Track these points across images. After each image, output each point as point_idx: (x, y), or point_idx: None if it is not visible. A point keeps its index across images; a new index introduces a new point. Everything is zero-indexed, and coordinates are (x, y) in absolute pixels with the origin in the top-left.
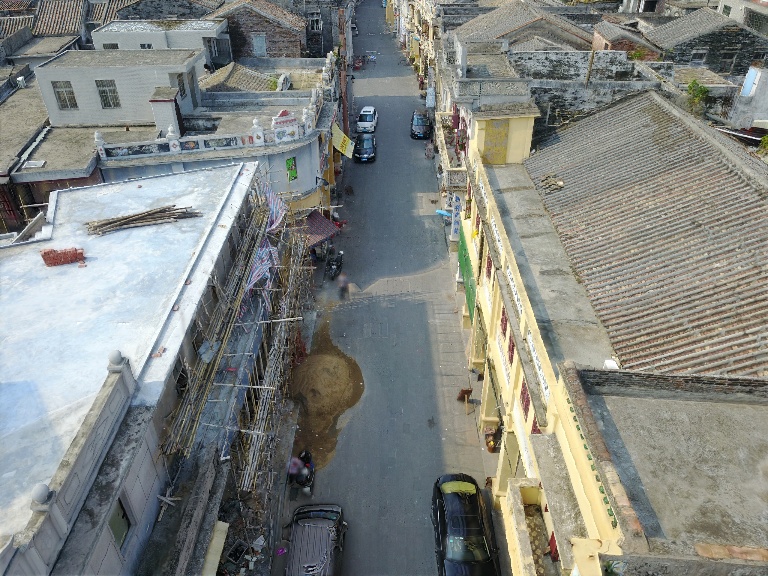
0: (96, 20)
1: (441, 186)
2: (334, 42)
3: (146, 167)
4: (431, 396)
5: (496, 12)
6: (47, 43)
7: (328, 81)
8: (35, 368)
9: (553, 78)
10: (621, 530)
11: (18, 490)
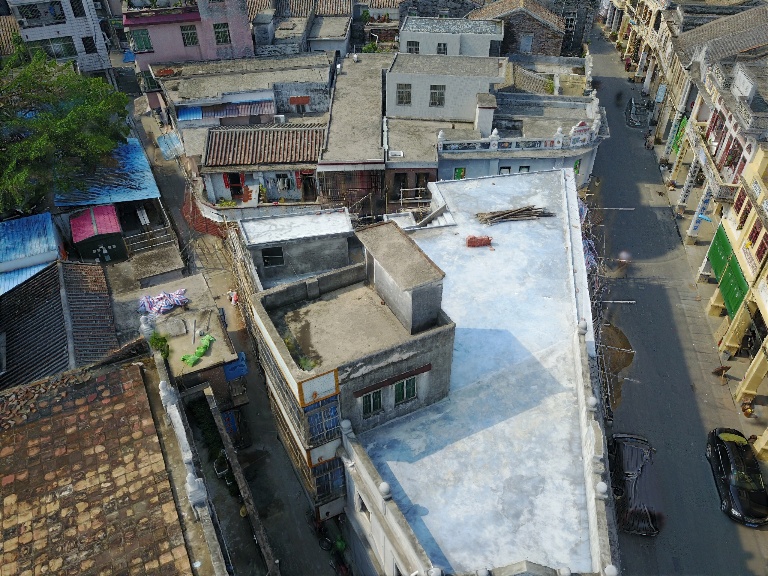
0: (362, 1)
1: (668, 180)
2: (584, 39)
3: (471, 160)
4: (690, 367)
5: (740, 16)
6: (330, 24)
7: None
8: (507, 322)
9: None
10: None
11: (545, 397)
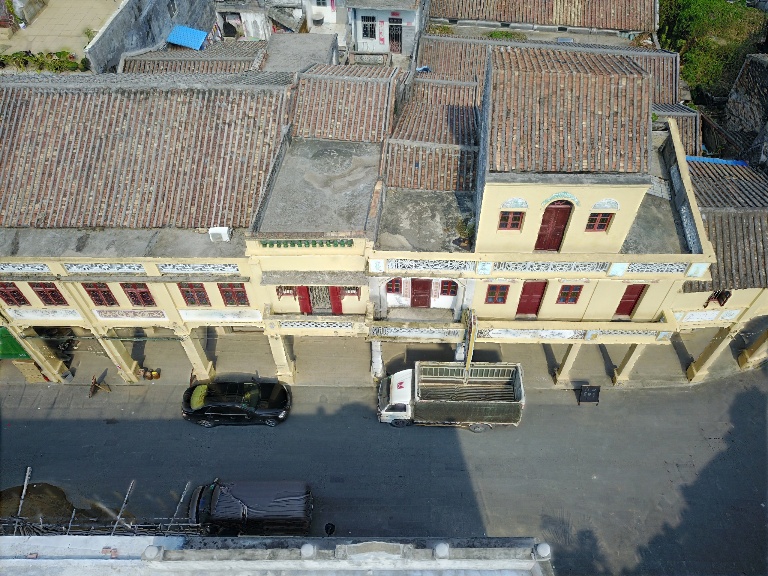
0: None
1: None
2: None
3: None
4: (77, 419)
5: None
6: None
7: None
8: None
9: None
10: (363, 238)
11: None
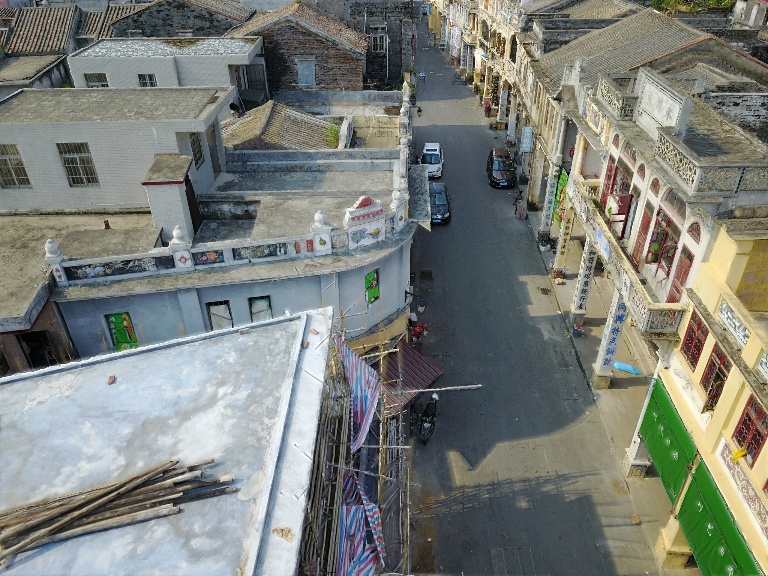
0: (89, 34)
1: (553, 268)
2: (403, 67)
3: (134, 297)
4: None
5: (617, 26)
6: (22, 65)
7: (407, 128)
8: None
9: (767, 134)
10: None
11: None
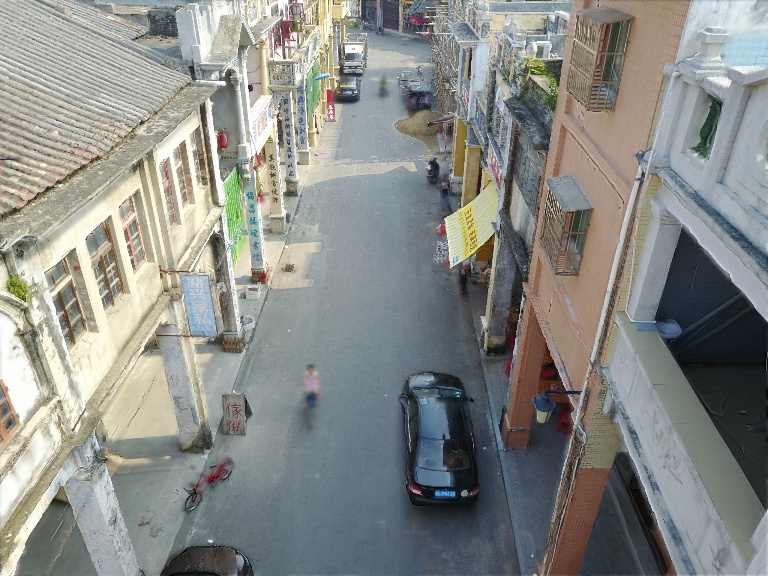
0: None
1: None
2: None
3: None
4: (351, 122)
5: None
6: None
7: None
8: None
9: None
10: None
11: None
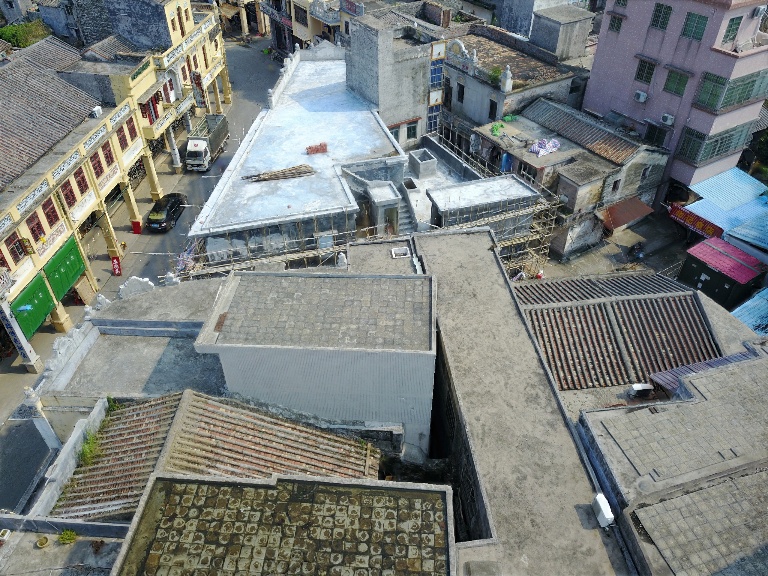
0: None
1: None
2: None
3: None
4: None
5: None
6: None
7: None
8: None
9: None
10: None
11: None
